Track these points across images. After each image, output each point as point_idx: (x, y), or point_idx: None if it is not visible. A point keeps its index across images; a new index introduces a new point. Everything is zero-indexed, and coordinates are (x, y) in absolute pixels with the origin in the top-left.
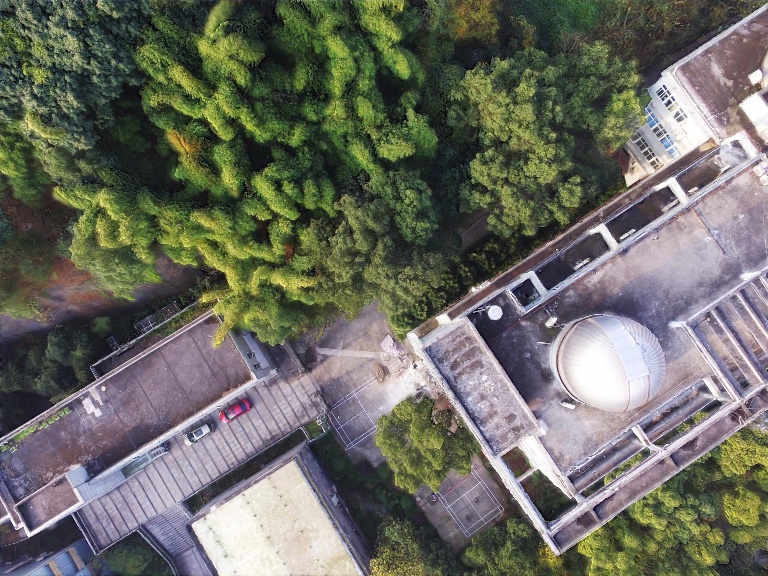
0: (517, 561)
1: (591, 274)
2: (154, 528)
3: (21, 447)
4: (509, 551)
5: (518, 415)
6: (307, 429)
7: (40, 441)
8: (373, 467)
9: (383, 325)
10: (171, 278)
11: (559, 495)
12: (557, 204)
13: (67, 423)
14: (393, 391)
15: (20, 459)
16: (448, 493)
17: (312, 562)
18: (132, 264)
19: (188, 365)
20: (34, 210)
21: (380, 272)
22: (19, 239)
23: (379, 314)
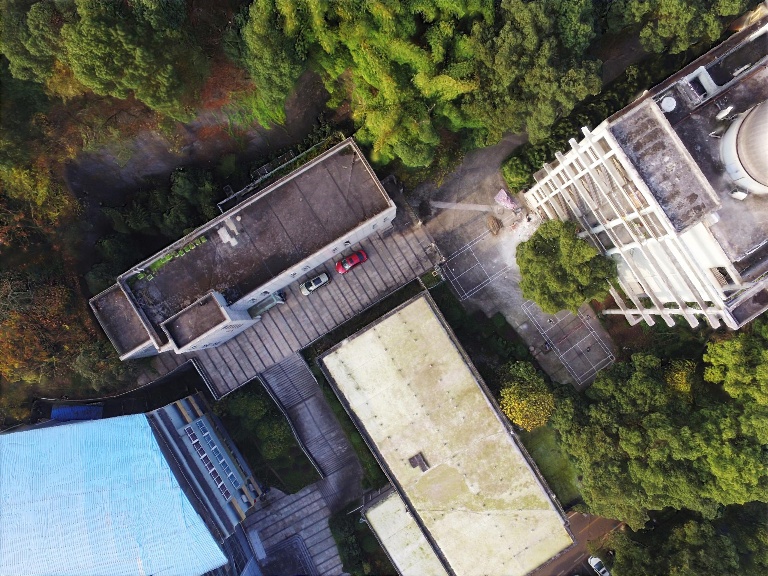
0: (648, 386)
1: (762, 68)
2: (271, 378)
3: (157, 275)
4: (638, 378)
5: (699, 195)
6: (422, 280)
7: (176, 269)
8: (488, 318)
9: (497, 179)
10: (292, 122)
11: (670, 343)
12: (714, 14)
13: (203, 252)
14: (507, 244)
15: (157, 287)
16: (561, 342)
17: (442, 394)
18: (293, 64)
19: (323, 196)
20: (197, 2)
21: (544, 73)
22: (186, 28)
23: (493, 168)
